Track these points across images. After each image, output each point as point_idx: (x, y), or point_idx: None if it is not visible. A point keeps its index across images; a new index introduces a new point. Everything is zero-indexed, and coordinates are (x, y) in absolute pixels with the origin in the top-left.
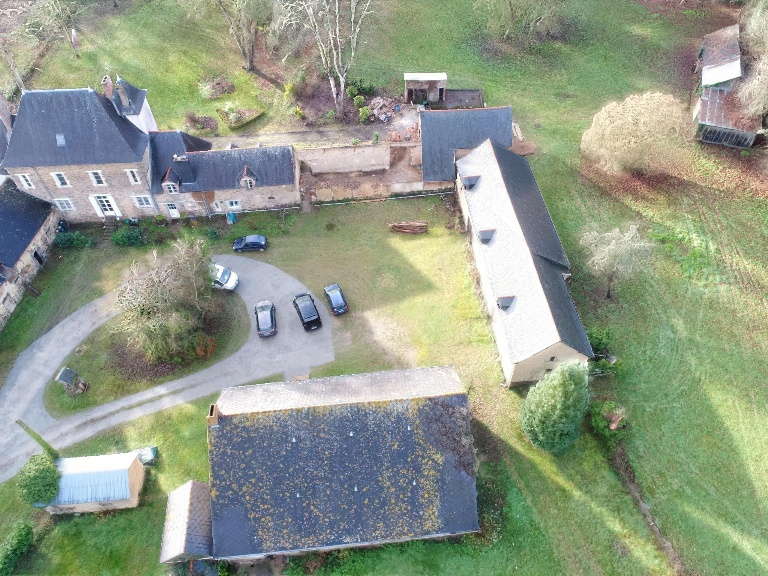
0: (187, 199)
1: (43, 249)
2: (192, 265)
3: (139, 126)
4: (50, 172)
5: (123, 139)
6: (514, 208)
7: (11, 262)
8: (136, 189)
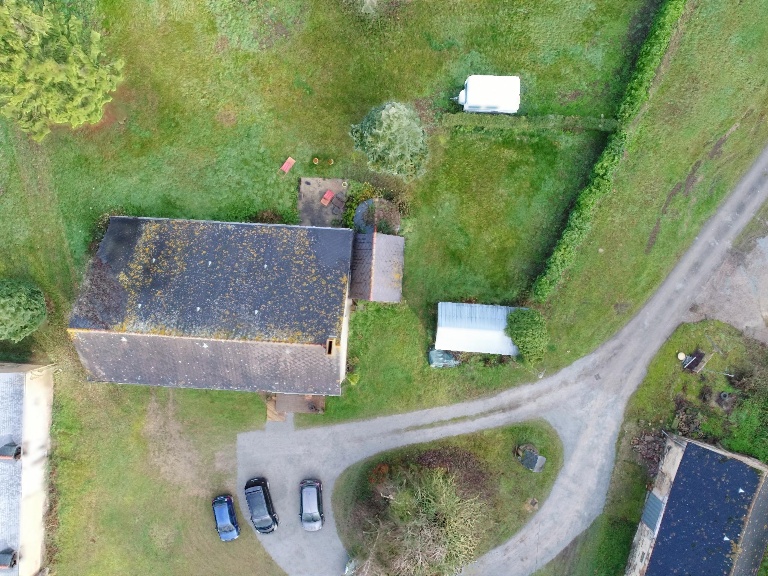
0: None
1: None
2: (369, 567)
3: None
4: None
5: None
6: None
7: None
8: None
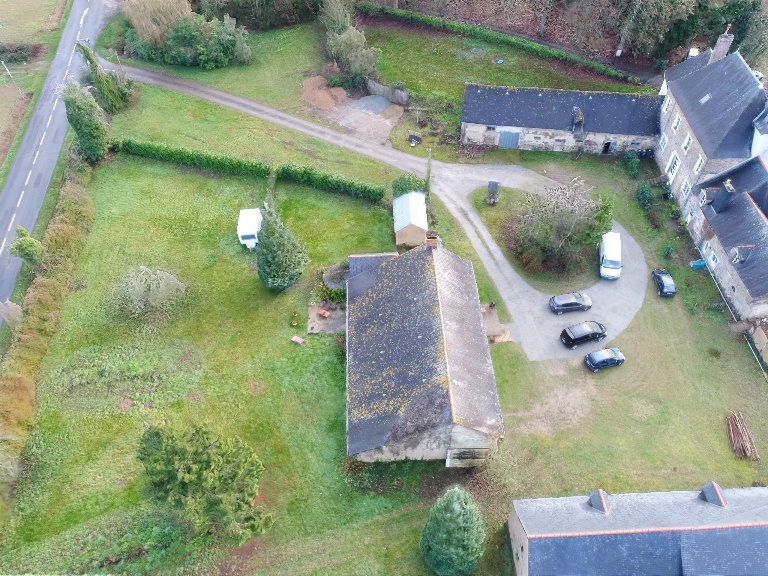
0: (701, 218)
1: (618, 148)
2: None
3: (754, 143)
4: (678, 112)
5: (725, 135)
6: (764, 527)
7: (589, 129)
8: (692, 176)
